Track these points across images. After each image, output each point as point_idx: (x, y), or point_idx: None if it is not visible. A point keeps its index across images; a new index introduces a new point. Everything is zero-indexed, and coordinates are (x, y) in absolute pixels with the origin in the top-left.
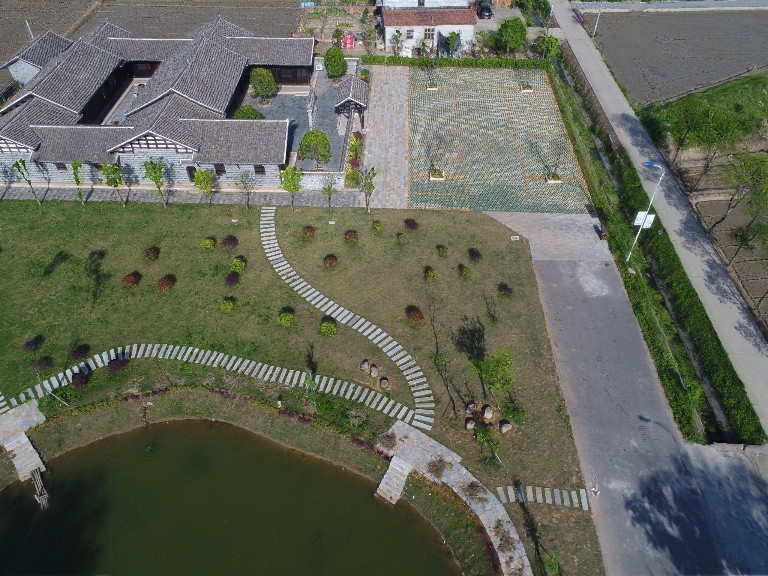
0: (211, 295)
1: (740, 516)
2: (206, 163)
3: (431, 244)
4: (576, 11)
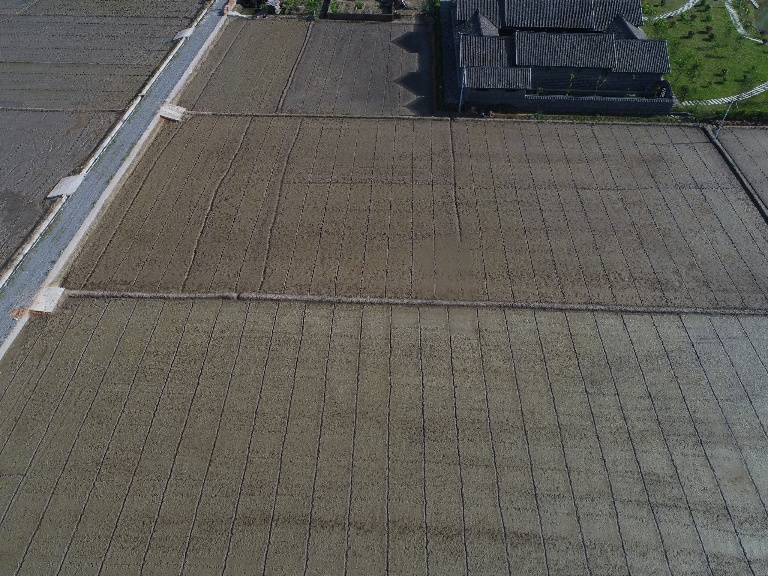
0: None
1: None
2: None
3: None
4: None
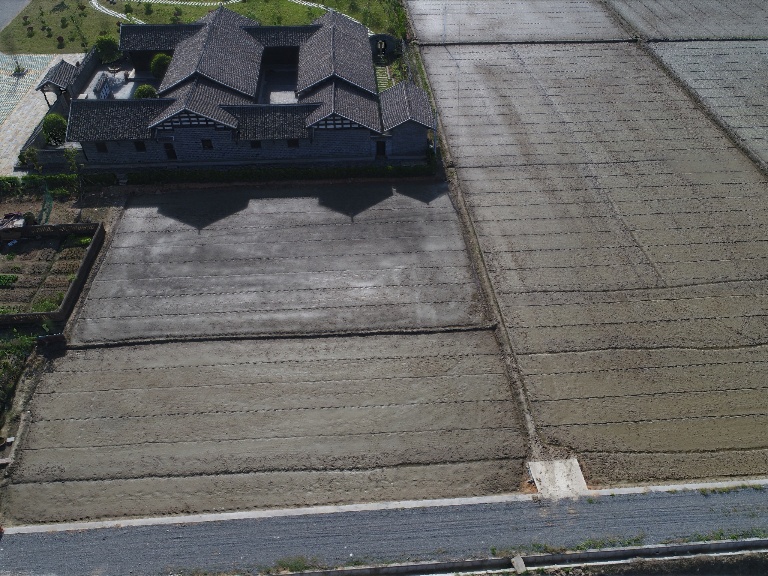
0: (188, 15)
1: None
2: None
3: (55, 37)
4: None
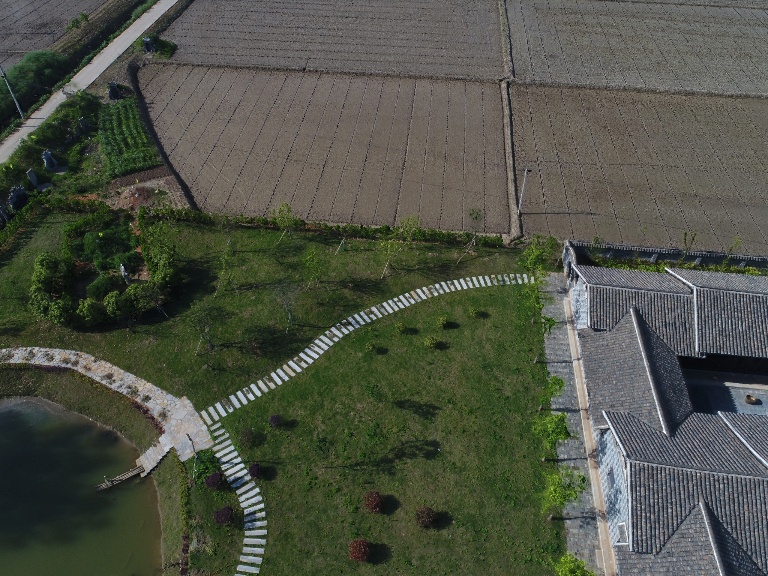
0: None
1: None
2: (620, 571)
3: None
4: None
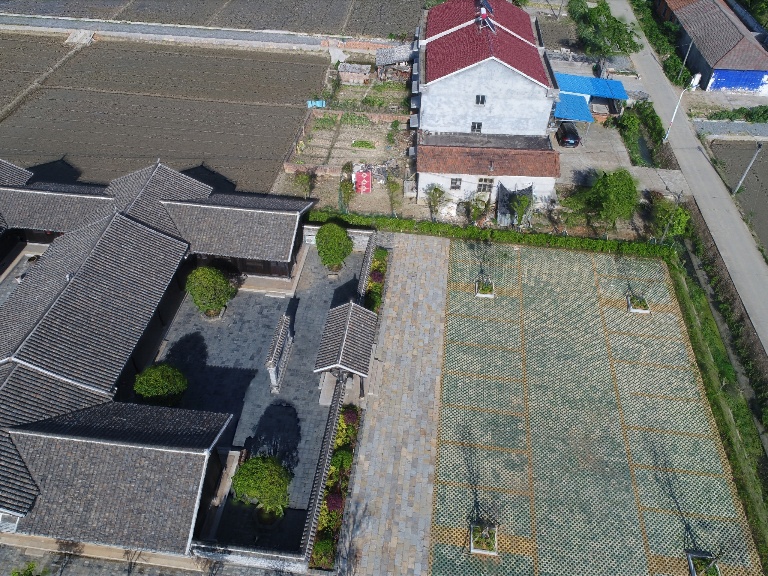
0: None
1: None
2: (42, 534)
3: None
4: (702, 138)
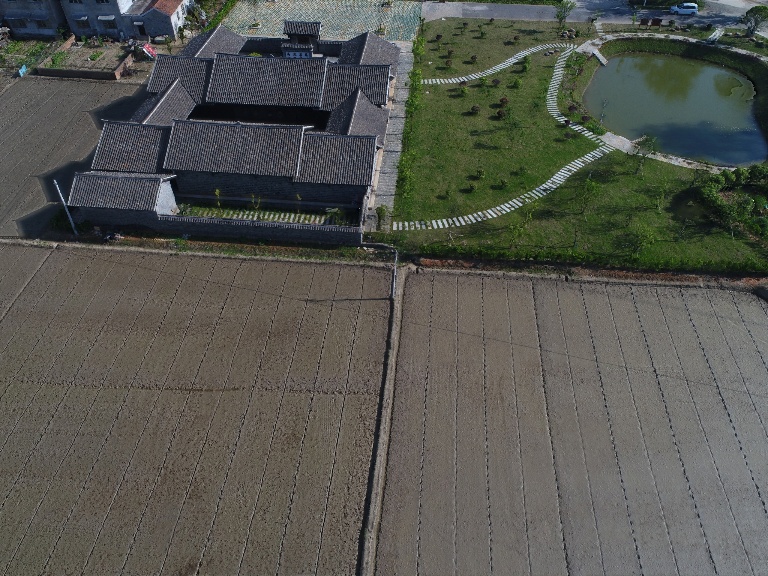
0: None
1: (593, 3)
2: None
3: None
4: None
